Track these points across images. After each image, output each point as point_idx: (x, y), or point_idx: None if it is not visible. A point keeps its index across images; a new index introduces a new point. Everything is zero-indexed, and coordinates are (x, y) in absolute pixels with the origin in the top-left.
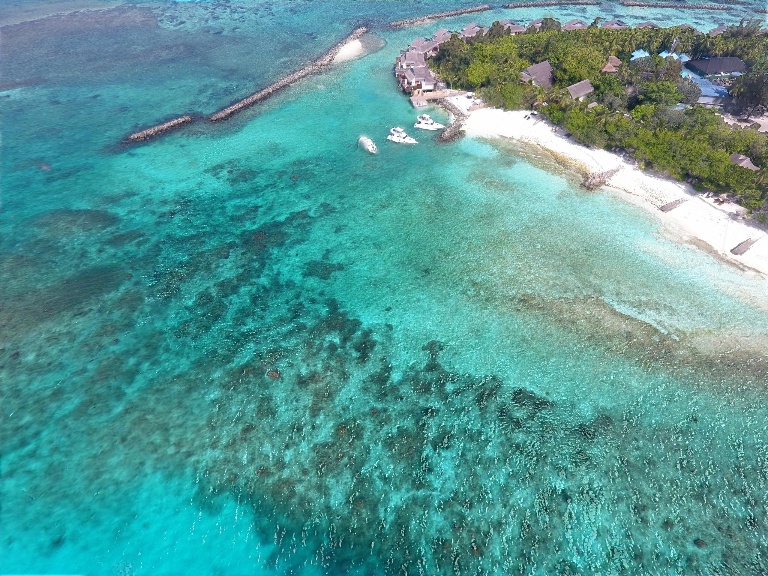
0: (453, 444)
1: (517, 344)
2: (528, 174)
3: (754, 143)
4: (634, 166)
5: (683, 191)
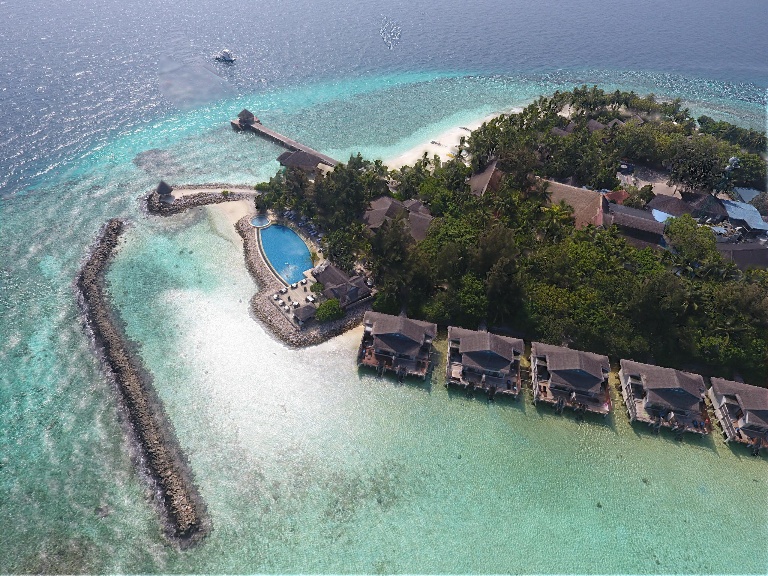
0: (763, 96)
1: (763, 110)
2: None
3: None
4: None
5: None
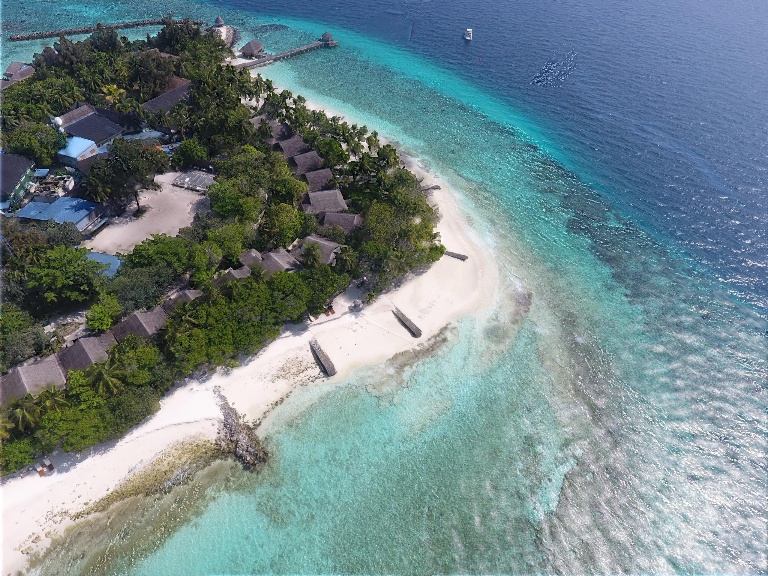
0: None
1: None
2: (185, 570)
3: (243, 235)
4: (219, 372)
5: (296, 336)
